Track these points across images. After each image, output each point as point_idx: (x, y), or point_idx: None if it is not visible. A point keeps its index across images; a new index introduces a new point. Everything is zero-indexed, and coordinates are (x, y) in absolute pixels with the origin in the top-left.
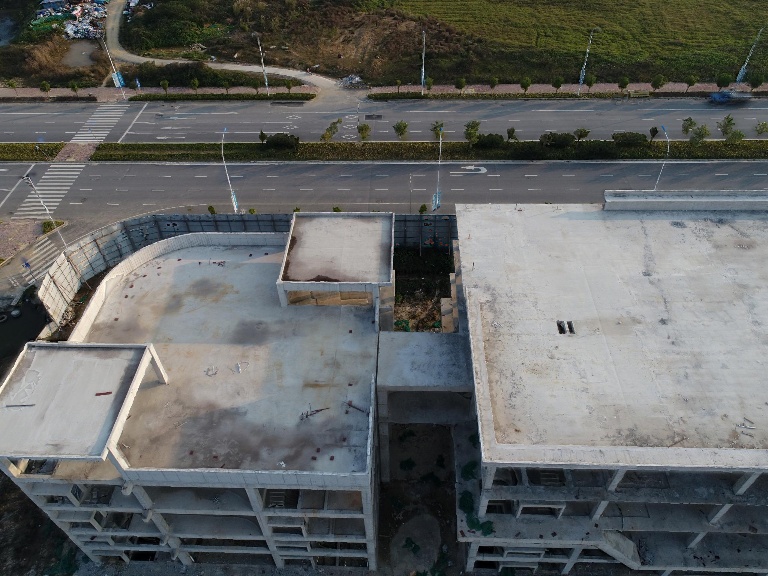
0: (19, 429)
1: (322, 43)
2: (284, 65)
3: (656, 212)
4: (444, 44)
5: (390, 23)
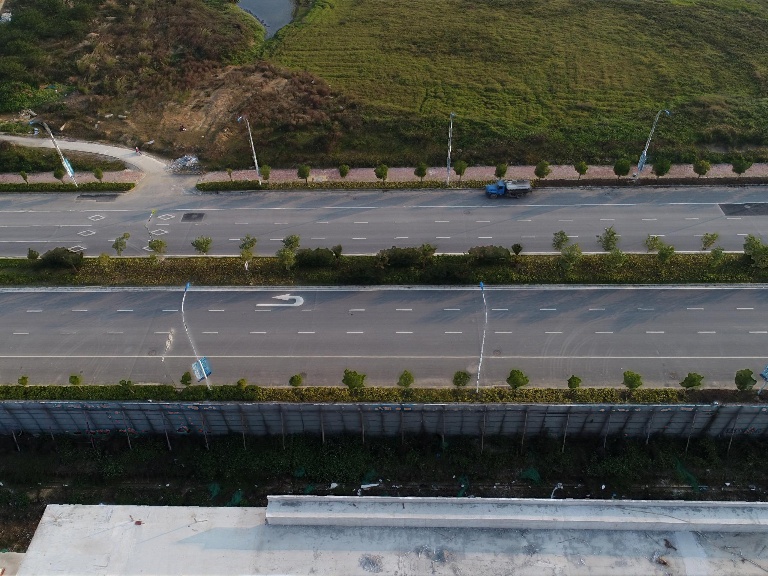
0: None
1: (168, 110)
2: (114, 140)
3: (348, 530)
4: (307, 112)
5: (256, 82)
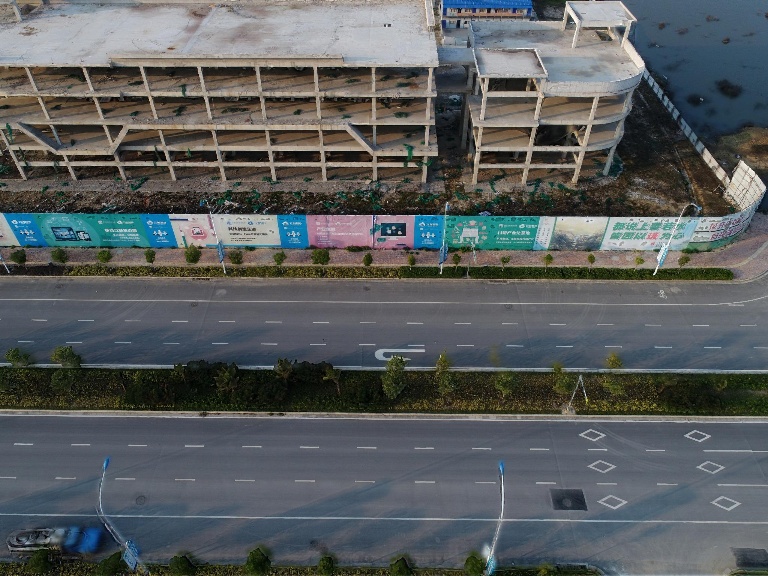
0: (607, 7)
1: None
2: None
3: None
4: None
5: None
